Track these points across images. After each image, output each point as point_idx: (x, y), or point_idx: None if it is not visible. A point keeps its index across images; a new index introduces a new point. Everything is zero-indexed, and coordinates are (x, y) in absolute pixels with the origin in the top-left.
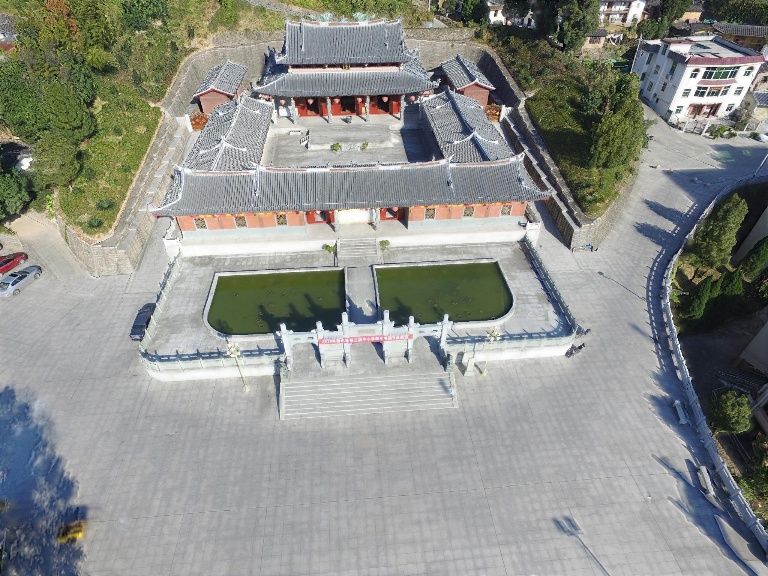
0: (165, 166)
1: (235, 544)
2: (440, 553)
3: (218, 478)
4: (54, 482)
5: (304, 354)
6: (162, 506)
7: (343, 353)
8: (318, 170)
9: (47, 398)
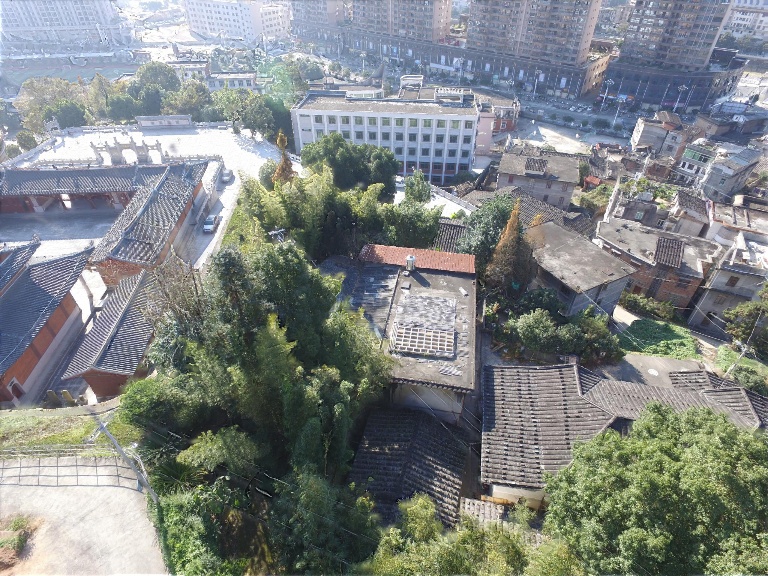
0: (219, 230)
1: (195, 142)
2: (140, 141)
3: (198, 149)
4: (249, 149)
5: (157, 162)
6: (215, 146)
7: (140, 158)
8: (97, 168)
9: (262, 162)
